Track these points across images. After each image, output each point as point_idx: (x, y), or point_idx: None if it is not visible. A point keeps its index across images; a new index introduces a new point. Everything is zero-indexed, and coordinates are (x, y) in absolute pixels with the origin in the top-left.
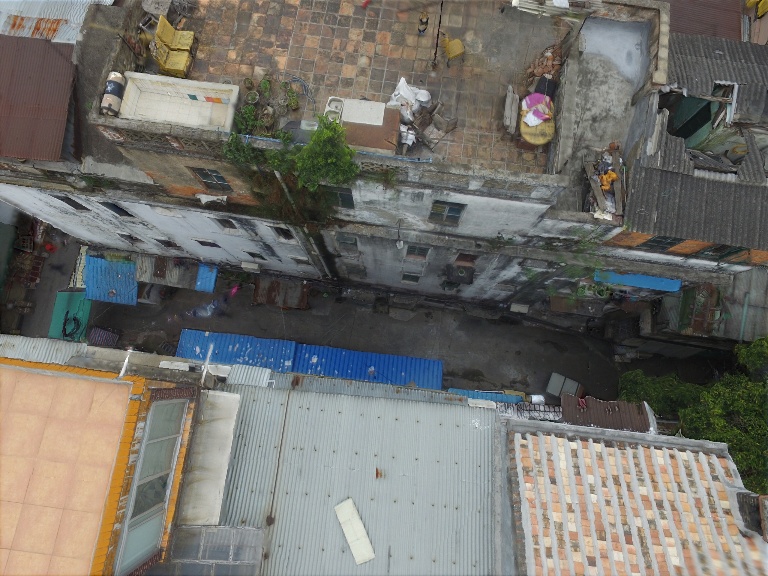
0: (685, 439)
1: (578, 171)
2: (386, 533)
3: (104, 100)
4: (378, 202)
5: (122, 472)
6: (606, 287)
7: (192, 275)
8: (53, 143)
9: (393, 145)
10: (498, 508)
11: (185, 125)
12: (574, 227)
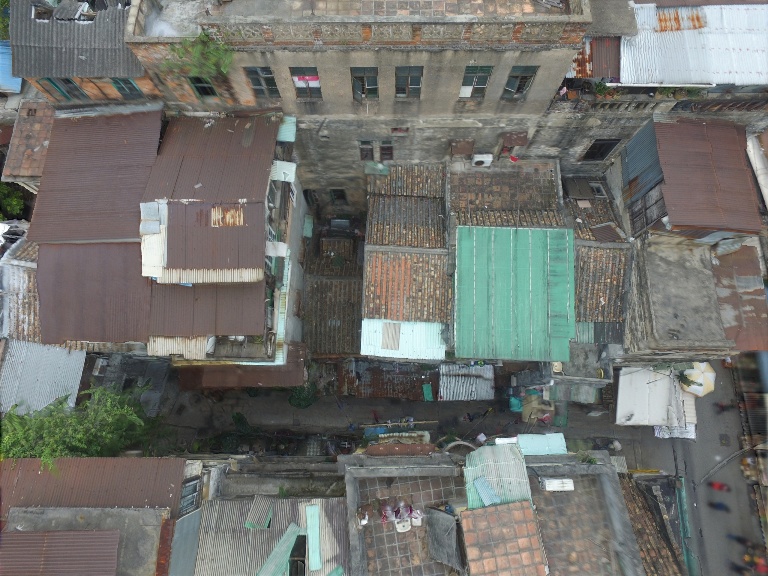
0: None
1: None
2: None
3: None
4: None
5: None
6: None
7: None
8: None
9: None
10: None
11: None
12: None
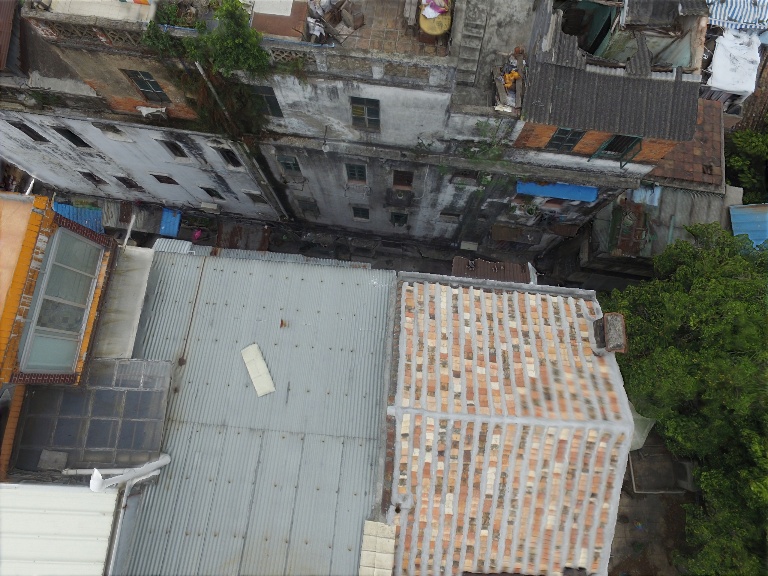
0: (558, 287)
1: (488, 76)
2: (287, 371)
3: None
4: (301, 104)
5: (24, 272)
6: (535, 207)
7: (157, 220)
8: None
9: (299, 33)
10: (389, 350)
11: (111, 19)
12: (481, 124)
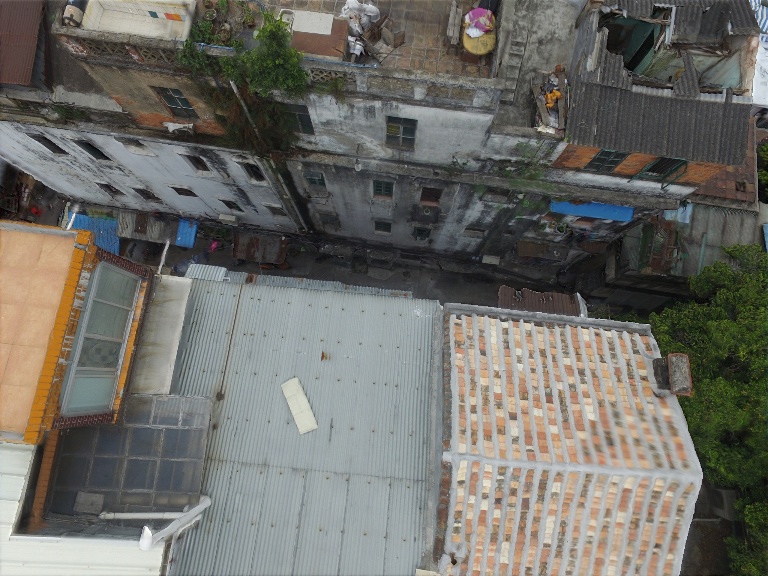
0: (611, 321)
1: (527, 94)
2: (329, 407)
3: (66, 11)
4: (335, 123)
5: (67, 312)
6: (566, 224)
7: (172, 231)
8: (23, 68)
9: (340, 52)
10: (435, 385)
11: (144, 36)
12: (521, 144)
